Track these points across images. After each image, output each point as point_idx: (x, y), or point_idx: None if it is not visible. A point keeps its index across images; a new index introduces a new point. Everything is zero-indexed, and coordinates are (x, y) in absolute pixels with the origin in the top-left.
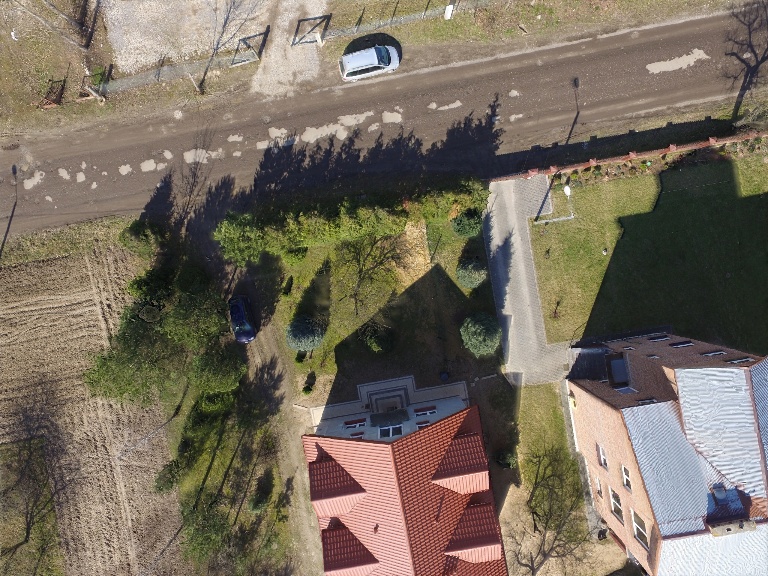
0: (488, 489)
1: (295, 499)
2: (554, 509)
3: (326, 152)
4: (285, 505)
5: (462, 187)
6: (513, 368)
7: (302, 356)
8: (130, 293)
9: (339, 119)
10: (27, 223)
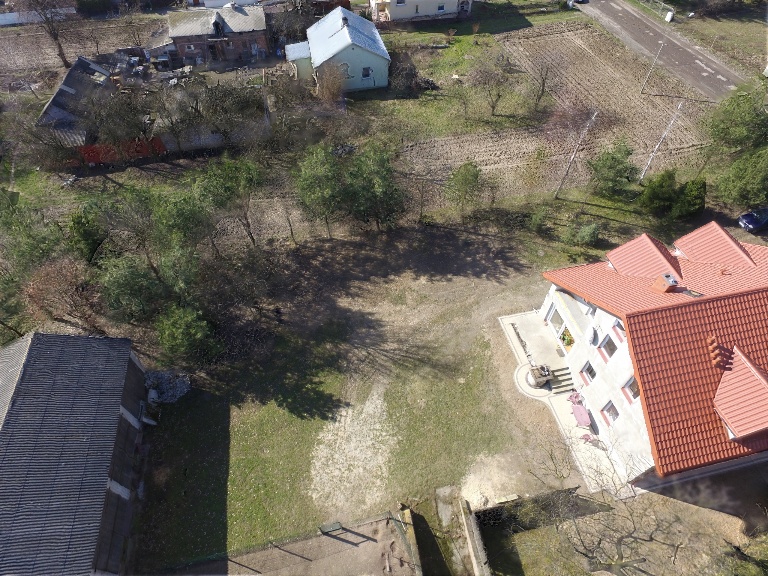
0: None
1: None
2: None
3: None
4: (587, 260)
5: None
6: None
7: None
8: None
9: None
10: None
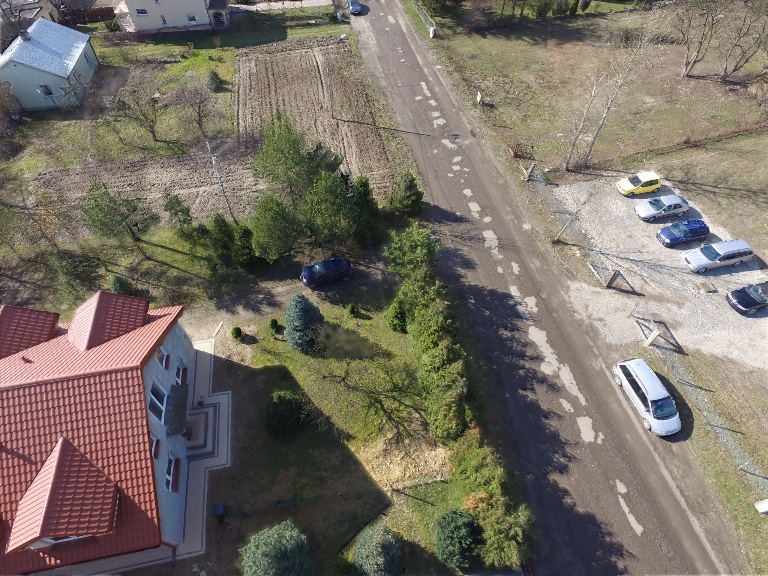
0: (7, 552)
1: None
2: None
3: (522, 352)
4: None
5: (515, 506)
6: None
7: (278, 330)
8: None
9: (565, 365)
10: (414, 141)
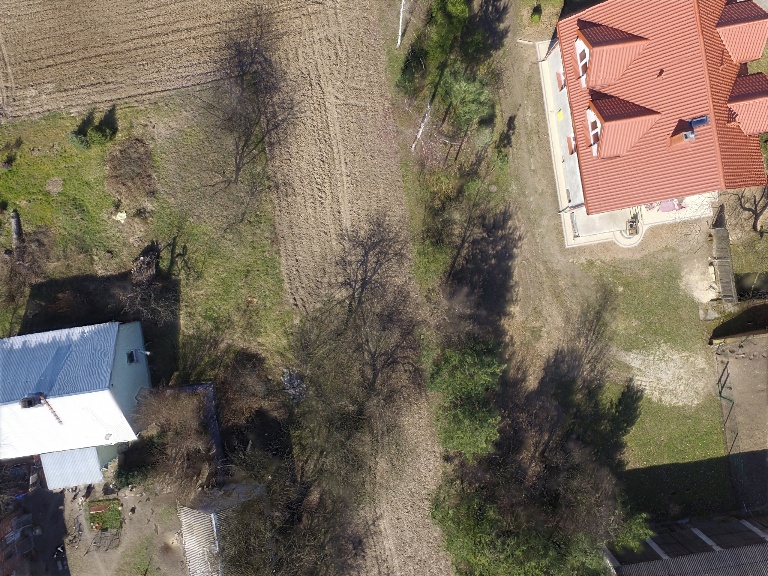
0: (759, 58)
1: (516, 139)
2: None
3: None
4: (506, 146)
5: None
6: None
7: None
8: None
9: None
10: None
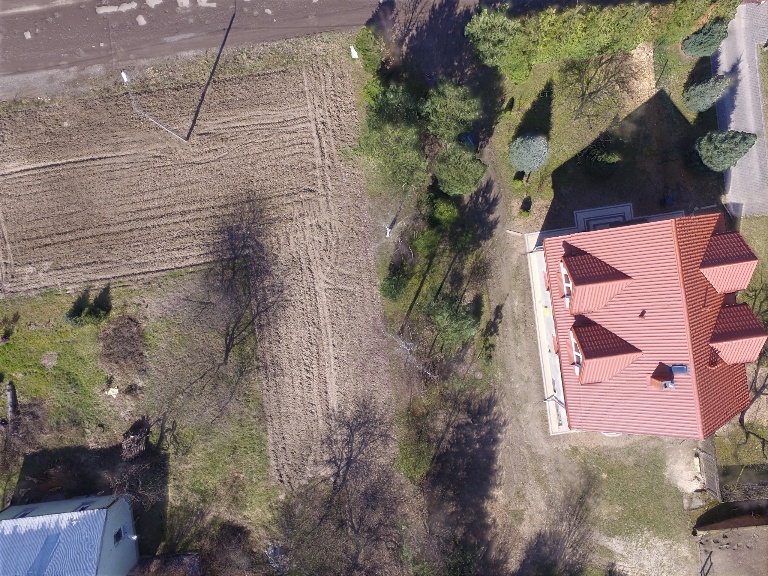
0: None
1: (503, 328)
2: (767, 345)
3: None
4: (493, 334)
5: None
6: (734, 198)
7: None
8: (345, 111)
9: None
10: (244, 36)
